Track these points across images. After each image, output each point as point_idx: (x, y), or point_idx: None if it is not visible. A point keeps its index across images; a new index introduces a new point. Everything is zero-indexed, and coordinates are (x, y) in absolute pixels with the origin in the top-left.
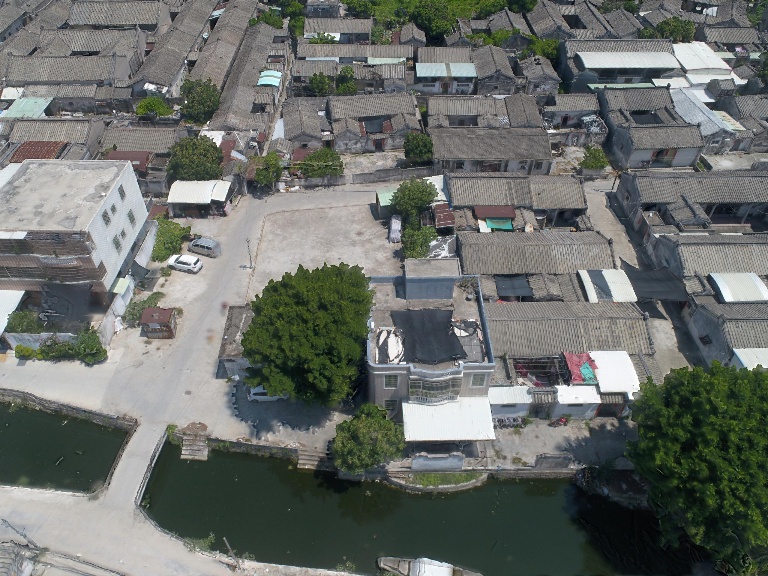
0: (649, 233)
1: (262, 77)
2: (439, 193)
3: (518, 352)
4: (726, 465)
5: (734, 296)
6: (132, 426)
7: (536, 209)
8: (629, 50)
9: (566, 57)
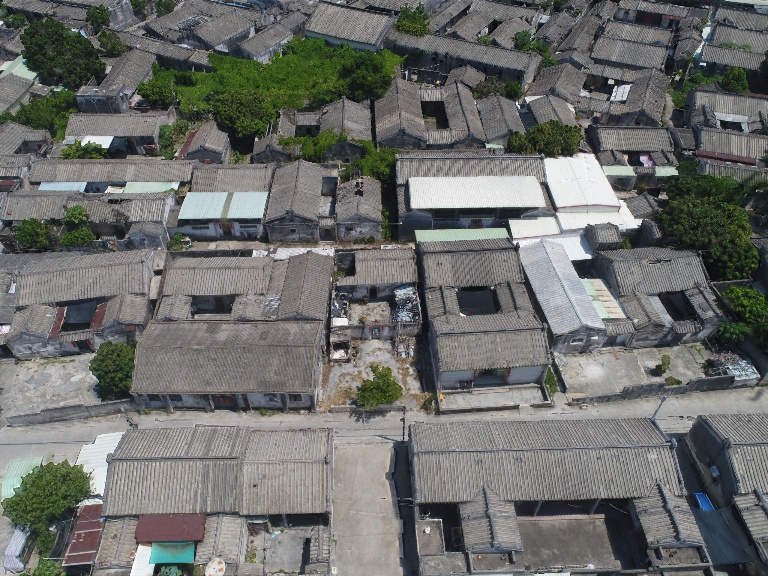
0: None
1: None
2: (102, 476)
3: None
4: None
5: None
6: None
7: (246, 514)
8: (483, 173)
9: (396, 183)
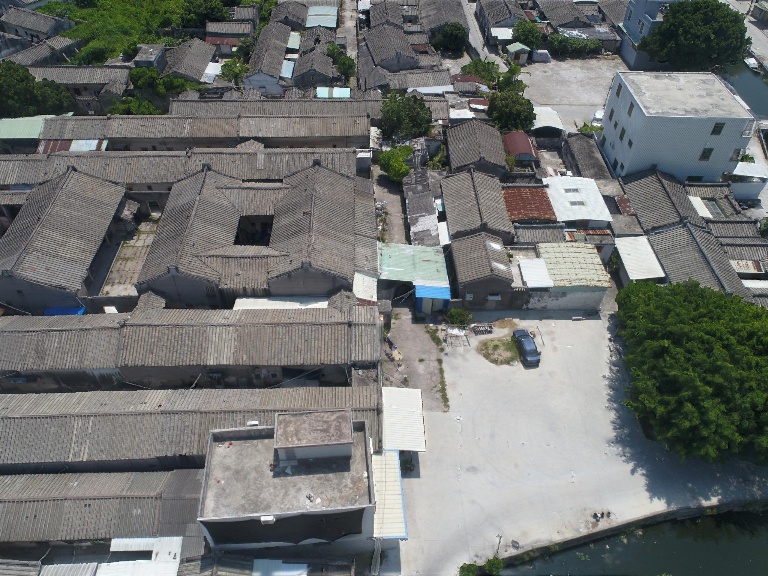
0: None
1: (332, 95)
2: None
3: None
4: None
5: None
6: (765, 124)
7: None
8: None
9: None
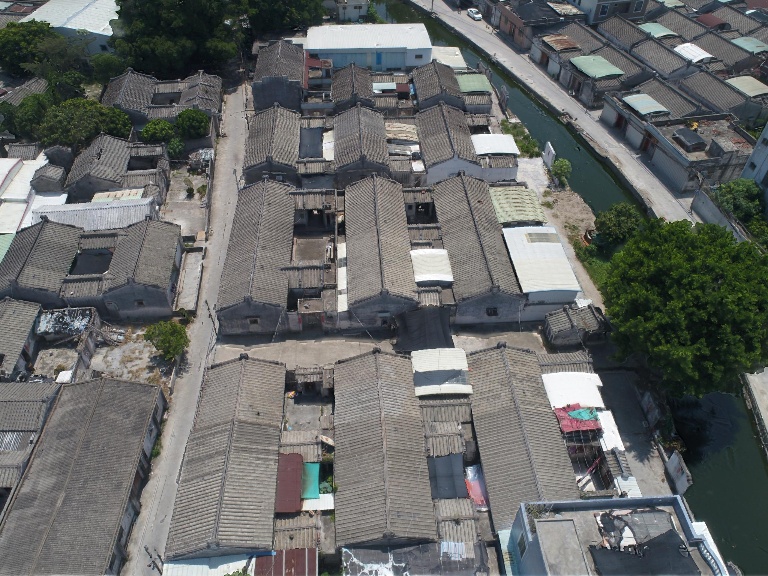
0: (329, 316)
1: None
2: (221, 574)
3: (573, 482)
4: (763, 315)
5: (447, 273)
6: None
7: None
8: None
9: None
